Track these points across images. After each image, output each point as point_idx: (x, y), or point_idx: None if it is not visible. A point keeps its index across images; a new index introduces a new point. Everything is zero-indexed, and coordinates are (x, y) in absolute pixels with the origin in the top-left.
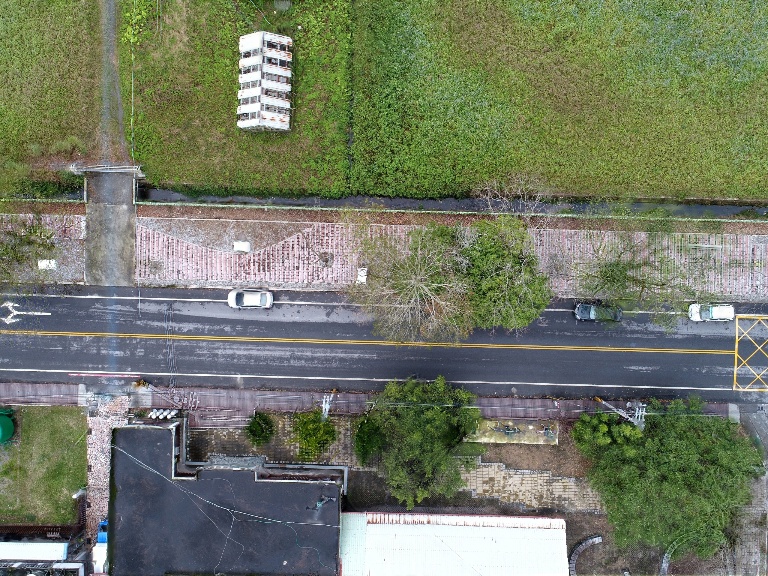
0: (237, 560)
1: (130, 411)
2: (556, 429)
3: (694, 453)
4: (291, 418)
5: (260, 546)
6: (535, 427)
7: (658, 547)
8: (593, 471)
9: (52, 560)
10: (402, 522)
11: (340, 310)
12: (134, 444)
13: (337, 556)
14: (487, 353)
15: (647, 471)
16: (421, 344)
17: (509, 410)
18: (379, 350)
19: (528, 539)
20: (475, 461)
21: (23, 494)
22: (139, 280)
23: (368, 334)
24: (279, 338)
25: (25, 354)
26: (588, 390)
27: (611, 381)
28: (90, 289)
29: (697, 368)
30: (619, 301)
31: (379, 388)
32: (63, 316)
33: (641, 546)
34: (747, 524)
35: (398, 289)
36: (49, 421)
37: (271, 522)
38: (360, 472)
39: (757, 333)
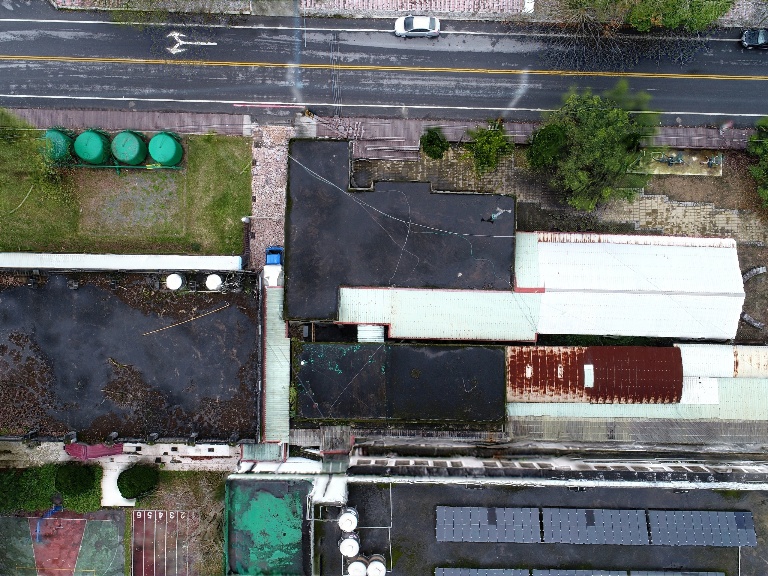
0: (412, 272)
1: None
2: (720, 160)
3: None
4: (455, 150)
5: (435, 258)
6: (699, 158)
7: None
8: (757, 202)
9: None
10: (573, 241)
11: (505, 40)
12: (310, 156)
13: (512, 268)
14: (652, 83)
15: None
16: (586, 73)
17: (674, 139)
18: (544, 80)
19: (700, 256)
20: (638, 193)
21: (189, 222)
22: (305, 10)
23: (533, 64)
24: (444, 68)
25: (190, 84)
26: (753, 120)
27: None
28: (256, 19)
29: None
30: None
31: (544, 118)
32: (229, 46)
33: None
34: None
35: (564, 18)
36: (215, 150)
37: (446, 234)
38: (523, 204)
39: None
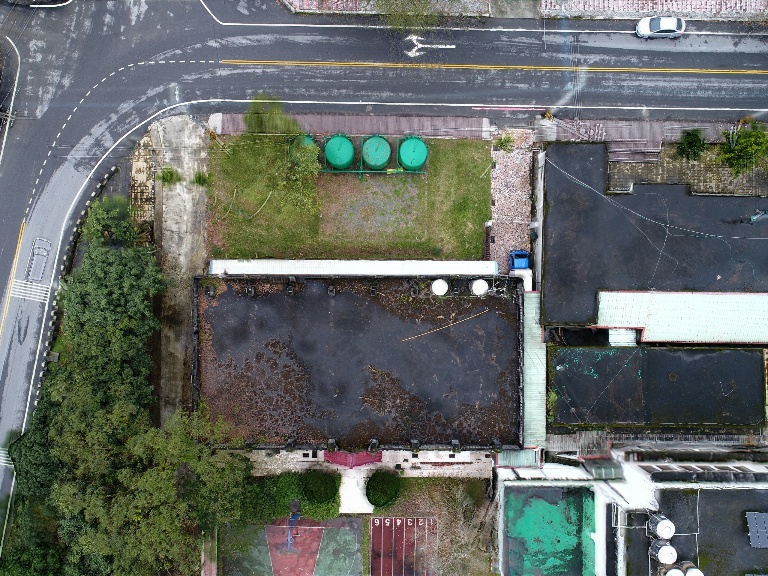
0: (671, 275)
1: (532, 146)
2: None
3: None
4: (695, 151)
5: (694, 261)
6: None
7: None
8: None
9: (487, 274)
10: None
11: (748, 40)
12: (567, 159)
13: None
14: None
15: None
16: None
17: None
18: None
19: None
20: None
21: (431, 226)
22: (545, 11)
23: None
24: (686, 69)
25: (429, 88)
26: None
27: None
28: (494, 21)
29: None
30: None
31: None
32: (467, 49)
33: None
34: None
35: None
36: (455, 154)
37: (705, 236)
38: None
39: None
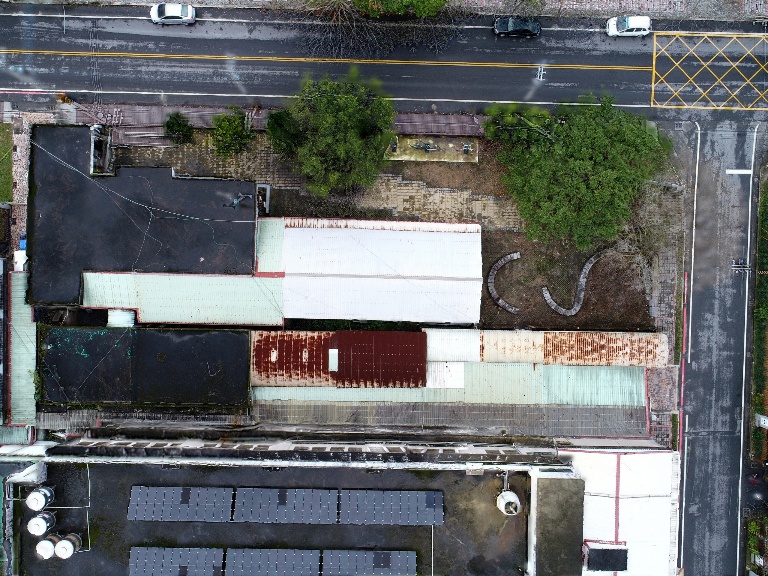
0: (155, 257)
1: None
2: (476, 147)
3: (602, 136)
4: (214, 136)
5: (177, 243)
6: (455, 145)
7: (576, 265)
8: (512, 189)
9: None
10: (320, 226)
11: (262, 27)
12: (53, 142)
13: (253, 253)
14: (407, 70)
15: (566, 189)
16: (342, 61)
17: (429, 126)
18: (301, 67)
19: (443, 241)
20: (396, 179)
21: None
22: None
23: (290, 51)
24: (202, 55)
25: None
26: (507, 107)
27: (530, 98)
28: (15, 7)
29: (615, 84)
30: (538, 18)
31: None
32: None
33: (560, 264)
34: (665, 242)
35: (319, 6)
36: None
37: (188, 219)
38: (282, 190)
39: (675, 49)
